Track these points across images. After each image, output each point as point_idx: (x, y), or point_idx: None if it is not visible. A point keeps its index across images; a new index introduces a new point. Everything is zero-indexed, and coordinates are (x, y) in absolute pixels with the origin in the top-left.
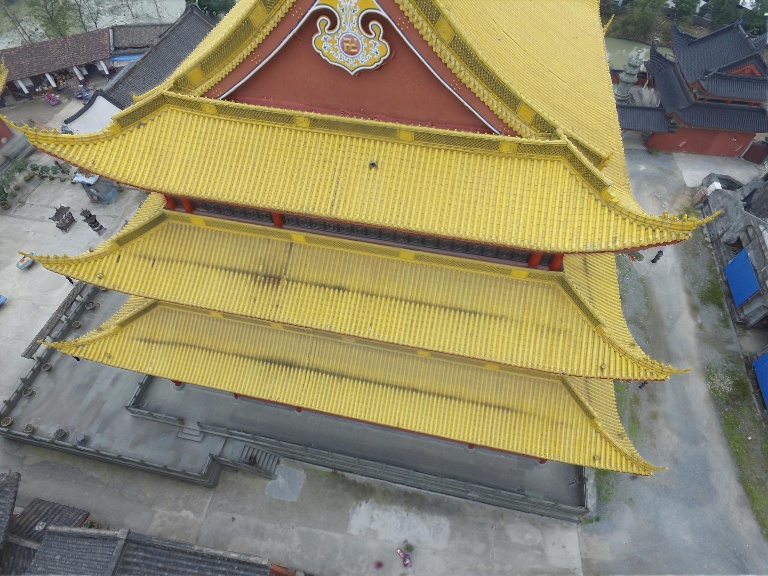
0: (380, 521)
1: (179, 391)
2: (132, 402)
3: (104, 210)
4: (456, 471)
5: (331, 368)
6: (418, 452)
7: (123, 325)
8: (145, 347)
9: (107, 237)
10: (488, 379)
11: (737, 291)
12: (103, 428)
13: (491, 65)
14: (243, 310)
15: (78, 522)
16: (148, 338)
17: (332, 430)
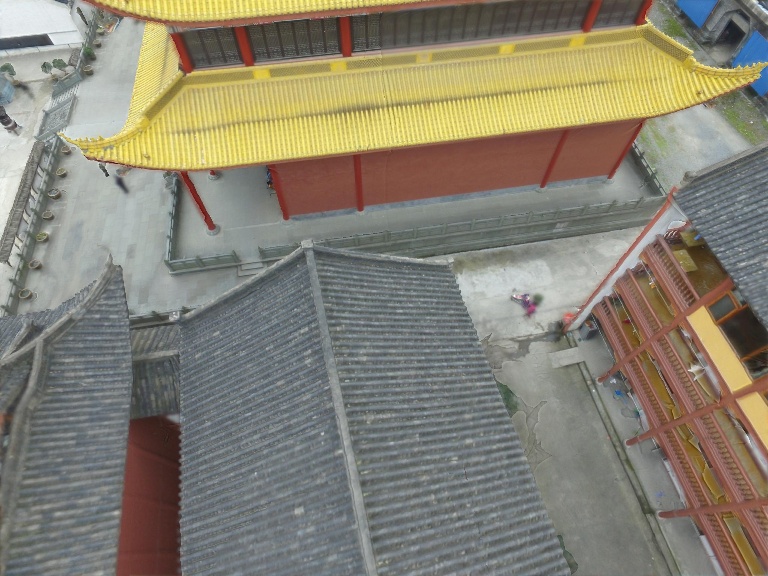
0: (482, 283)
1: (216, 235)
2: (169, 257)
3: (7, 110)
4: (538, 210)
5: (413, 98)
6: (495, 207)
7: (150, 117)
8: (186, 140)
9: (28, 134)
10: (575, 60)
11: (697, 13)
12: (144, 297)
13: None
14: (324, 3)
15: None
16: (186, 128)
17: (402, 217)
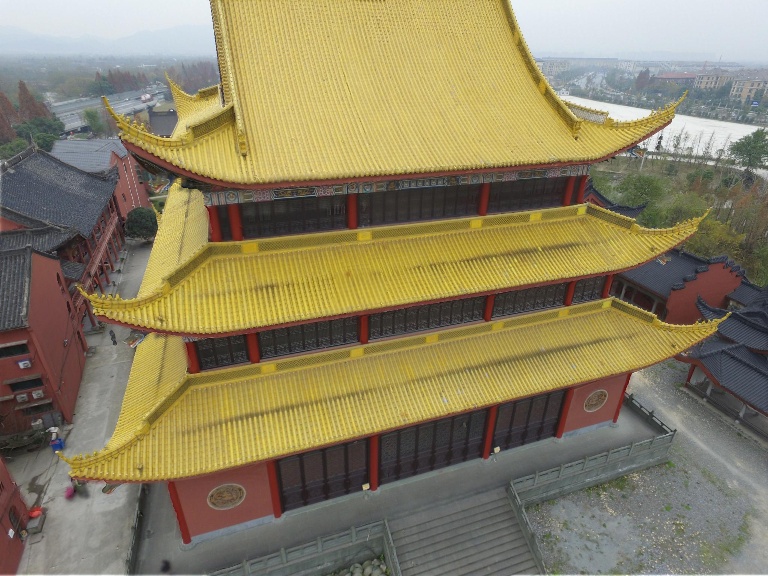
0: None
1: None
2: None
3: None
4: None
5: None
6: None
7: None
8: None
9: None
10: (184, 353)
11: None
12: None
13: (227, 52)
14: None
15: (70, 277)
16: None
17: None
